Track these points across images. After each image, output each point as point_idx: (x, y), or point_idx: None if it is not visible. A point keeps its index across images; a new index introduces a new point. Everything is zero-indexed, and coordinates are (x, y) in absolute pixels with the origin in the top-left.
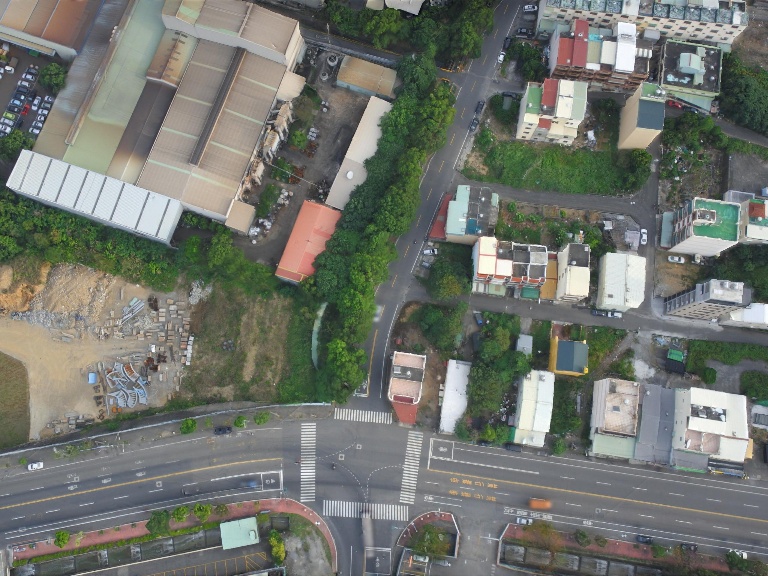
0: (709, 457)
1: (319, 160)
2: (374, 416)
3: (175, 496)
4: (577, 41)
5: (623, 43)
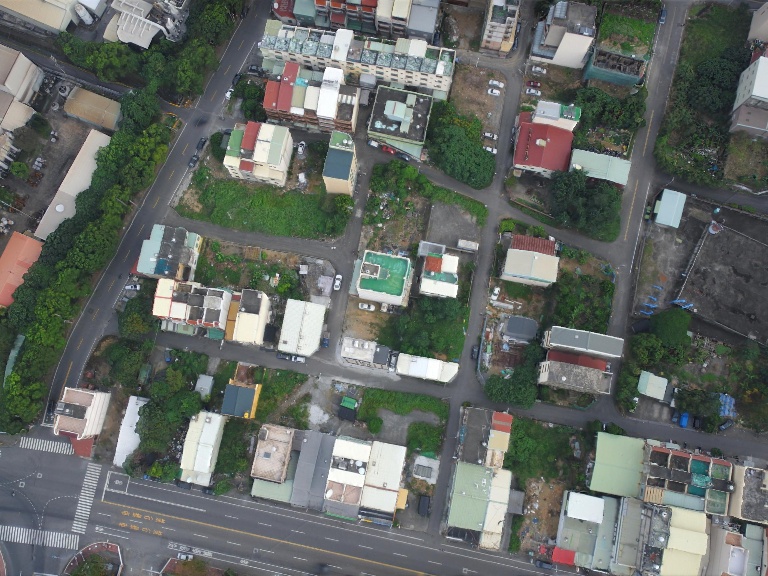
0: (360, 506)
1: (43, 190)
2: (58, 446)
3: None
4: (283, 85)
5: (325, 89)
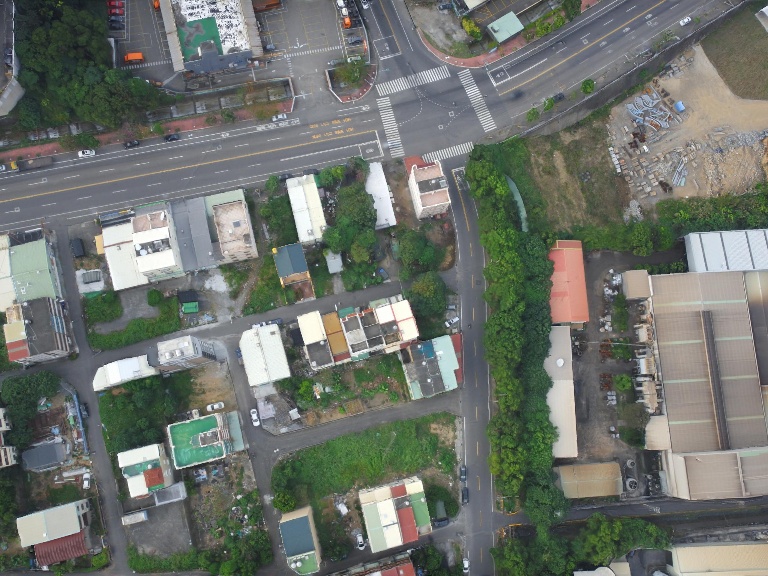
0: None
1: (593, 375)
2: (439, 156)
3: (568, 38)
4: None
5: None
